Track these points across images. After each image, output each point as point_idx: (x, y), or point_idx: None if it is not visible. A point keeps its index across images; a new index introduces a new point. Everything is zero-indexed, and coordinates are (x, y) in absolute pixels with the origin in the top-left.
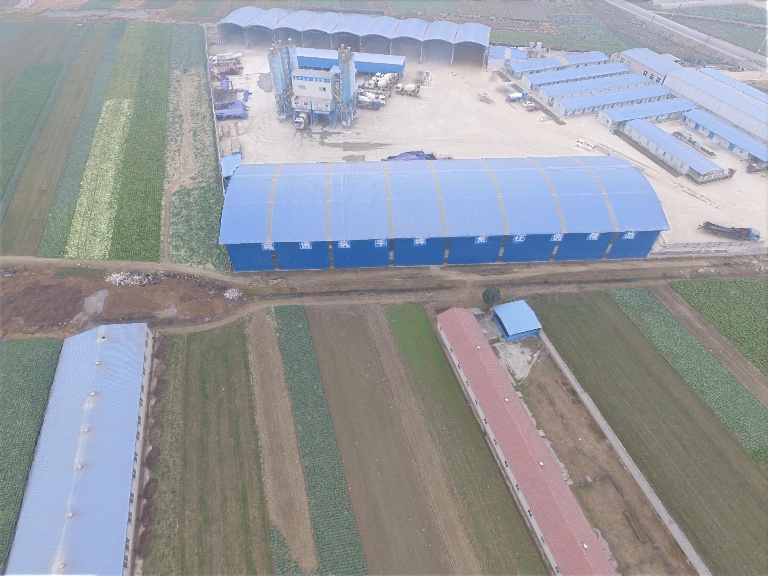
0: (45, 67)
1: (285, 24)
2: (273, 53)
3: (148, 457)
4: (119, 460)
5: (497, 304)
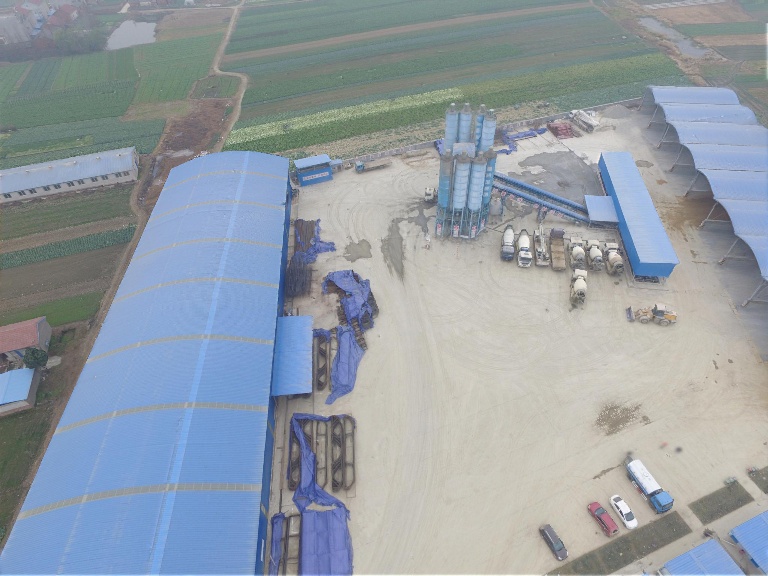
0: (510, 50)
1: (686, 125)
2: (456, 110)
3: None
4: (28, 183)
5: (54, 382)
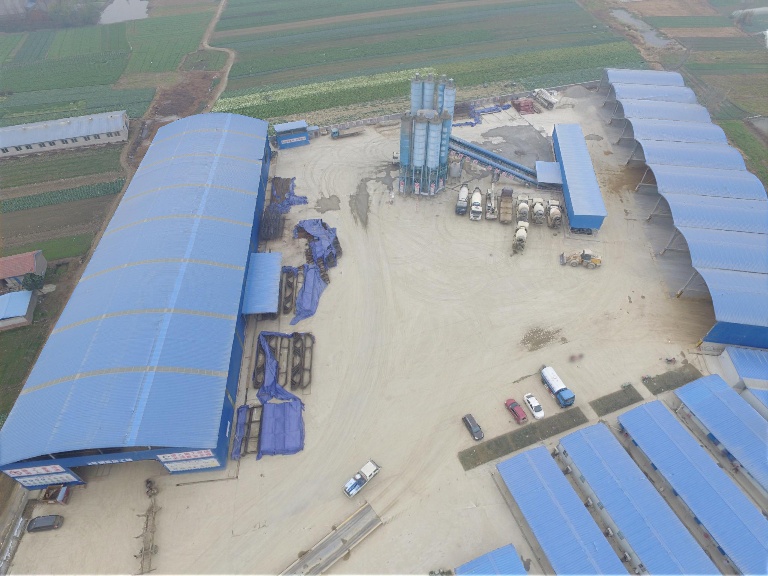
0: (485, 35)
1: (632, 102)
2: (421, 80)
3: (34, 154)
4: (24, 140)
5: (49, 305)
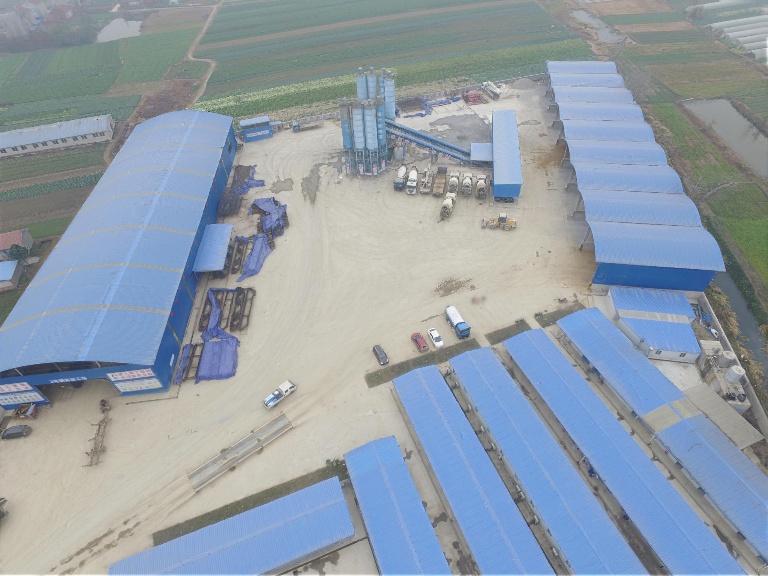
0: (448, 37)
1: (563, 88)
2: None
3: None
4: (20, 141)
5: (33, 273)
